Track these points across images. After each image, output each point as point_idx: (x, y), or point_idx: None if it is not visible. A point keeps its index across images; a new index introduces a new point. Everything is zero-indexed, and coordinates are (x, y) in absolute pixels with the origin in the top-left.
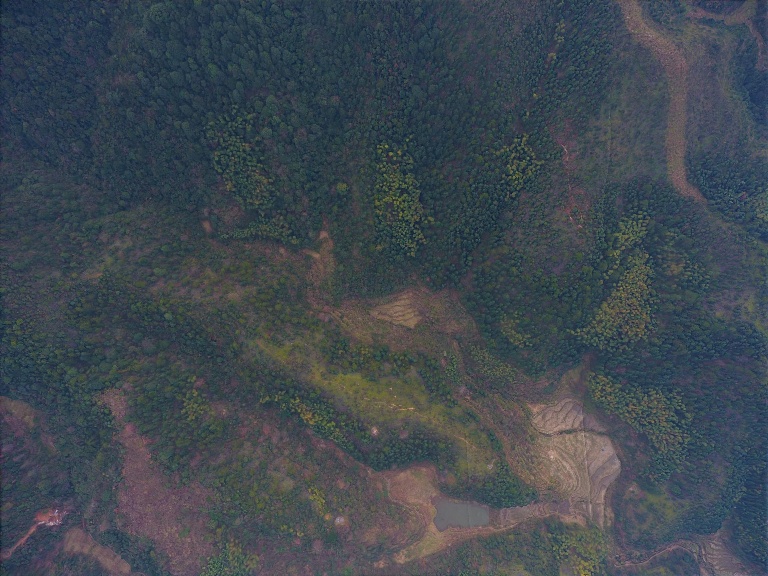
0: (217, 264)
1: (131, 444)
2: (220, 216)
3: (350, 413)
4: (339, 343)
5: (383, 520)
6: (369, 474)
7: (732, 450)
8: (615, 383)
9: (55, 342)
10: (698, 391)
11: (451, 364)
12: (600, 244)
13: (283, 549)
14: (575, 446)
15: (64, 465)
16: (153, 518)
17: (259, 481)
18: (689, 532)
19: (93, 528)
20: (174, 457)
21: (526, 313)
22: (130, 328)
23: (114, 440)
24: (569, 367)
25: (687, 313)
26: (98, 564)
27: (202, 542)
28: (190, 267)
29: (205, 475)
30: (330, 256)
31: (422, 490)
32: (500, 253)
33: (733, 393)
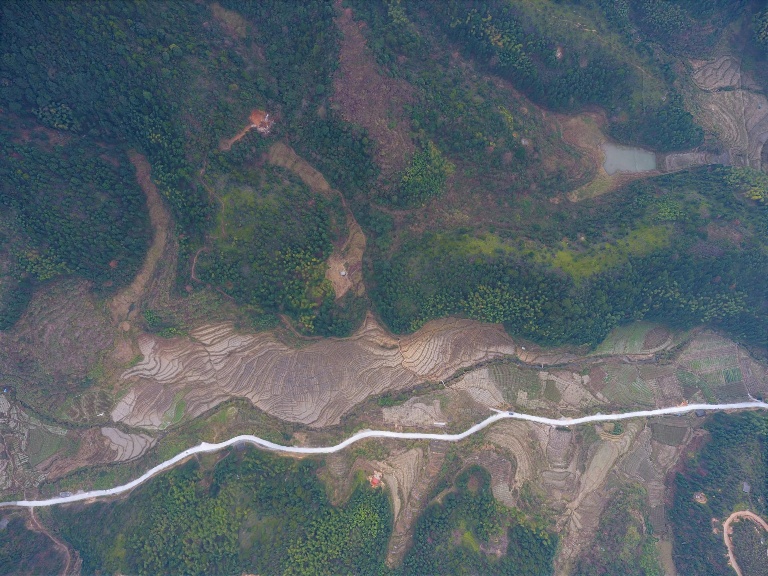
0: None
1: (348, 30)
2: None
3: (537, 33)
4: None
5: (560, 153)
6: (543, 117)
7: None
8: None
9: None
10: None
11: None
12: None
13: (470, 171)
14: (733, 102)
15: (274, 73)
16: (366, 105)
17: (456, 90)
18: None
19: (301, 132)
20: (385, 48)
21: None
22: None
23: (333, 25)
24: (731, 17)
25: None
26: (300, 178)
27: (407, 138)
28: None
29: (411, 73)
30: None
31: (592, 136)
32: None
33: None
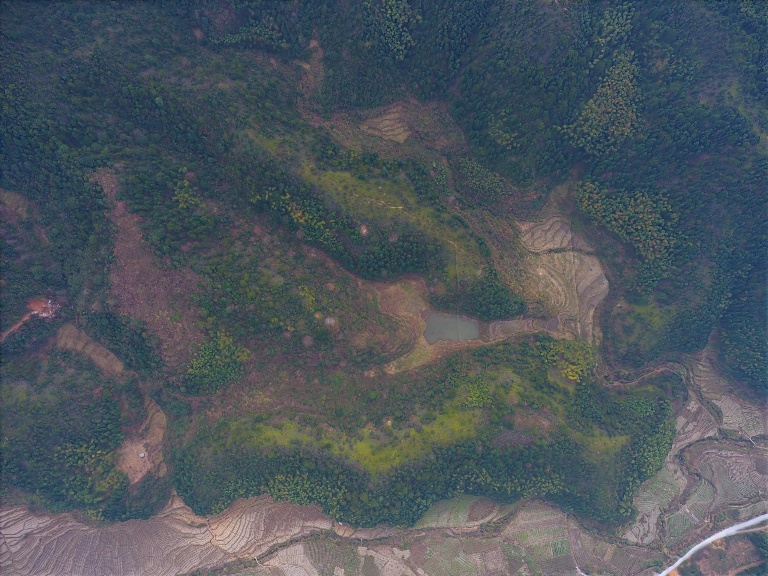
0: (208, 62)
1: (123, 223)
2: (211, 19)
3: (340, 211)
4: (329, 146)
5: (373, 327)
6: (359, 285)
7: (717, 250)
8: (602, 189)
9: (47, 114)
10: (683, 190)
11: (440, 175)
12: (585, 29)
13: (274, 350)
14: (563, 265)
15: (57, 256)
16: (145, 299)
17: (250, 274)
18: (676, 348)
19: (86, 318)
20: (165, 239)
21: (513, 112)
22: (122, 116)
23: (106, 218)
24: (557, 181)
25: (672, 104)
26: (91, 361)
27: (193, 328)
28: (181, 61)
29: (196, 261)
30: (320, 65)
31: (412, 304)
32: (487, 49)
33: (717, 184)
